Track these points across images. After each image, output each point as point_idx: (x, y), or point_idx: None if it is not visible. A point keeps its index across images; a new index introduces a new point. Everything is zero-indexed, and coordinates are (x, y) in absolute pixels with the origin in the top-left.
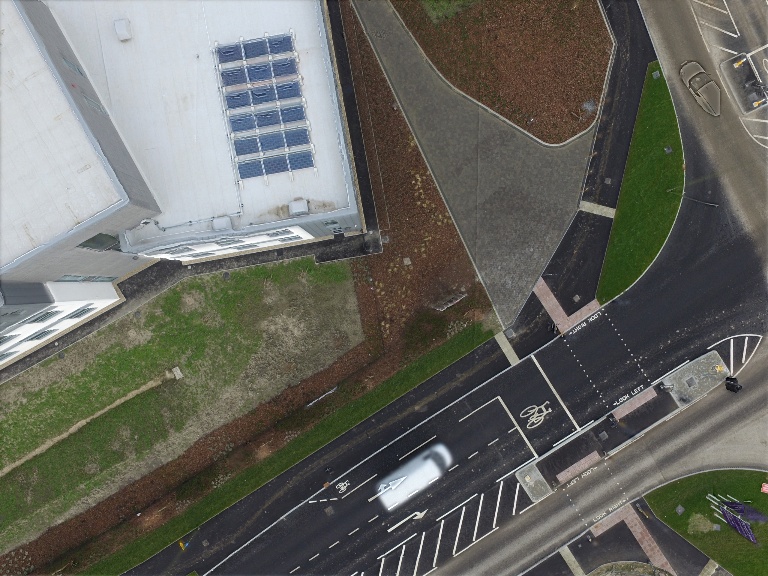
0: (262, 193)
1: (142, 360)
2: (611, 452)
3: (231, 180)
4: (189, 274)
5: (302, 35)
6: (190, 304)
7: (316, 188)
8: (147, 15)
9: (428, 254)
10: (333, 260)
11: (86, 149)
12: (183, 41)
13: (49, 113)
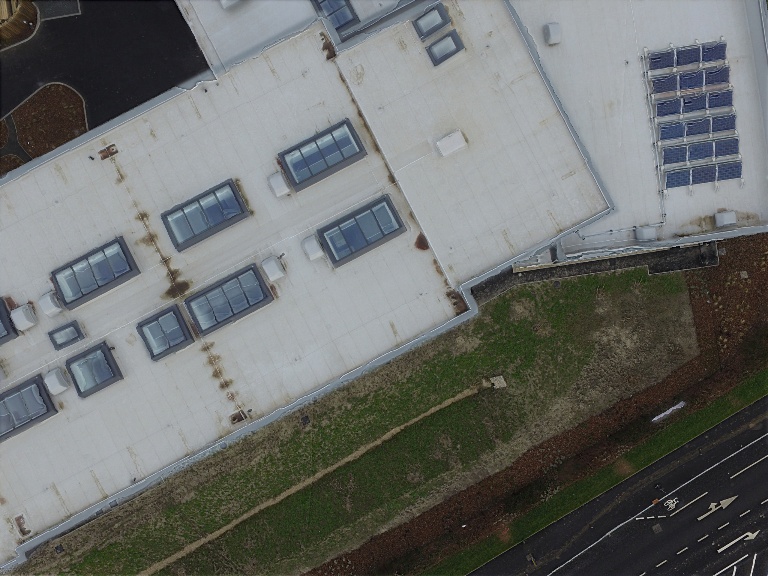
0: (685, 203)
1: (464, 368)
2: None
3: (654, 189)
4: (519, 282)
5: (733, 43)
6: (520, 312)
7: (740, 199)
8: (575, 19)
9: (767, 268)
10: (668, 271)
11: (572, 155)
12: (611, 46)
13: (535, 117)
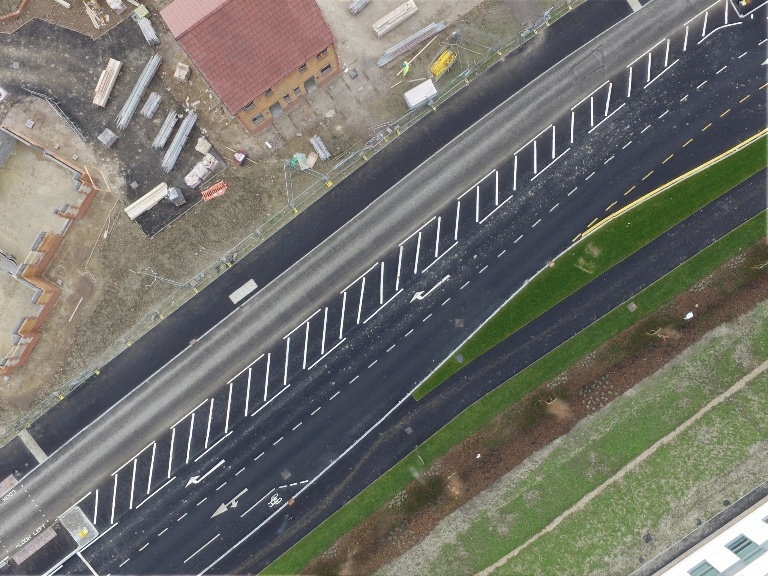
0: None
1: None
2: (3, 565)
3: None
4: None
5: None
6: None
7: None
8: None
9: None
10: None
11: None
12: None
13: None
